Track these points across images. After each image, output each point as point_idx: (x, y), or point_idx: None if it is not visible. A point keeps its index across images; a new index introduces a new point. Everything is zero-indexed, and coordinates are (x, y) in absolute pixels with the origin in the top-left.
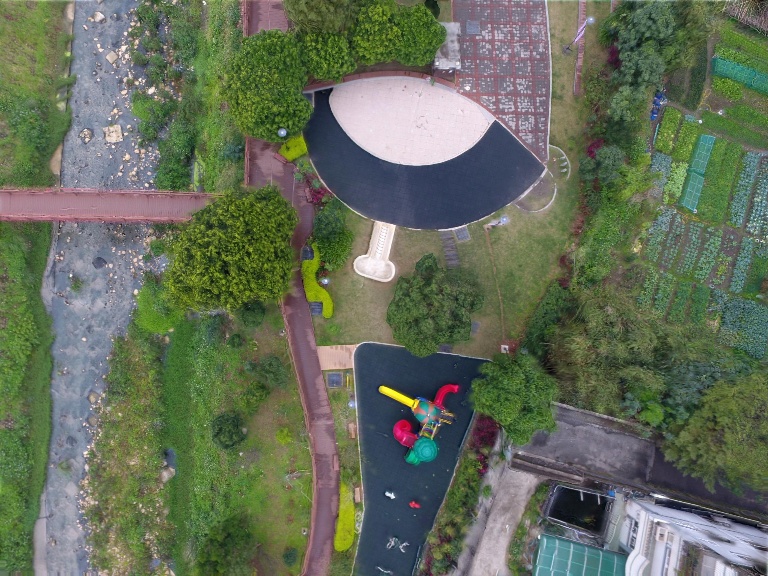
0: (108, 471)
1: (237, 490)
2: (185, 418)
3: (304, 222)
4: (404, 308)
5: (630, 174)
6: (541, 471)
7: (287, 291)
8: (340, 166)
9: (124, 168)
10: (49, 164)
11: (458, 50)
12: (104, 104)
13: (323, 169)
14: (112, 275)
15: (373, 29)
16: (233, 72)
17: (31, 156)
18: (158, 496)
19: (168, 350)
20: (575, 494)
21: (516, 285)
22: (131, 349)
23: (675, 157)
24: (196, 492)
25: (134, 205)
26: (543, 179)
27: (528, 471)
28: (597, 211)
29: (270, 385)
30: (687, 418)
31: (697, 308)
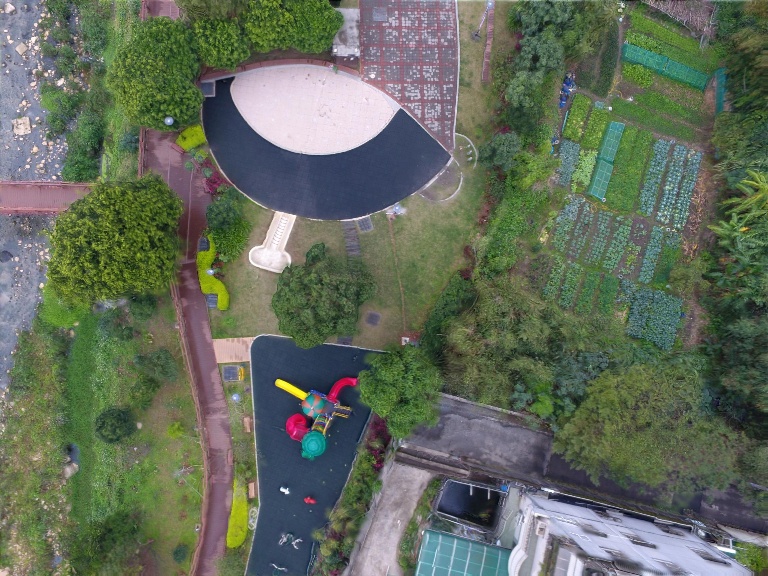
0: (11, 467)
1: (131, 486)
2: (88, 413)
3: (202, 213)
4: (284, 298)
5: (531, 162)
6: (426, 465)
7: (183, 283)
8: (240, 156)
9: (32, 160)
10: None
11: (357, 37)
12: (13, 96)
13: (223, 159)
14: (18, 269)
15: (263, 15)
16: (121, 60)
17: None
18: (60, 492)
19: (73, 344)
20: (465, 489)
21: (418, 276)
22: (35, 343)
23: (584, 145)
24: (95, 488)
25: (26, 196)
26: (449, 168)
27: (412, 465)
28: (501, 200)
29: (158, 378)
30: (574, 410)
31: (605, 299)
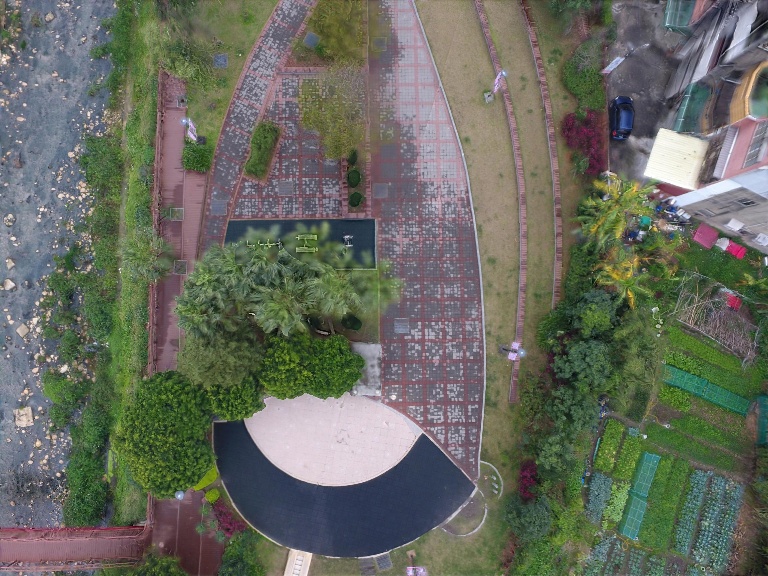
0: None
1: None
2: None
3: (213, 555)
4: None
5: (562, 518)
6: None
7: None
8: (254, 488)
9: (35, 455)
10: None
11: (378, 376)
12: (14, 382)
13: (235, 492)
14: (22, 574)
15: (279, 377)
16: (128, 424)
17: None
18: None
19: None
20: None
21: None
22: None
23: (616, 476)
24: None
25: (30, 545)
26: (473, 499)
27: None
28: (528, 544)
29: None
30: None
31: None
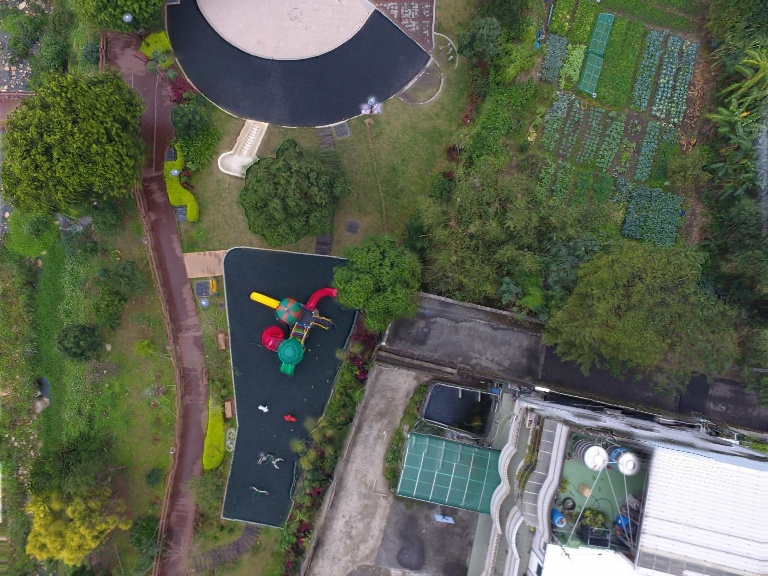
0: None
1: (102, 410)
2: None
3: (168, 123)
4: (252, 191)
5: (514, 52)
6: (409, 364)
7: (151, 196)
8: (208, 64)
9: None
10: None
11: None
12: None
13: (189, 67)
14: None
15: None
16: None
17: None
18: (31, 427)
19: (41, 274)
20: (453, 392)
21: (399, 180)
22: (1, 274)
23: (571, 39)
24: (66, 419)
25: None
26: (428, 69)
27: (395, 364)
28: (485, 98)
29: (125, 290)
30: (567, 297)
31: (599, 199)
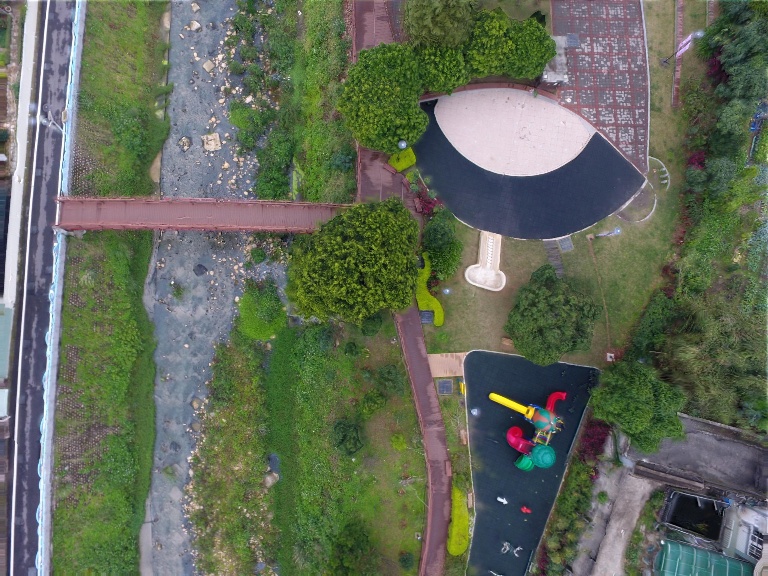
0: (213, 476)
1: (350, 495)
2: (289, 424)
3: None
4: (531, 318)
5: (735, 186)
6: (663, 478)
7: None
8: (446, 176)
9: (223, 176)
10: (149, 172)
11: (565, 63)
12: (201, 112)
13: (430, 179)
14: (213, 282)
15: (490, 43)
16: (353, 84)
17: (133, 164)
18: (263, 501)
19: (270, 357)
20: (692, 500)
21: (620, 294)
22: (234, 356)
23: None
24: (304, 497)
25: (249, 214)
26: (643, 190)
27: (650, 478)
28: (699, 222)
29: (389, 393)
30: None
31: None
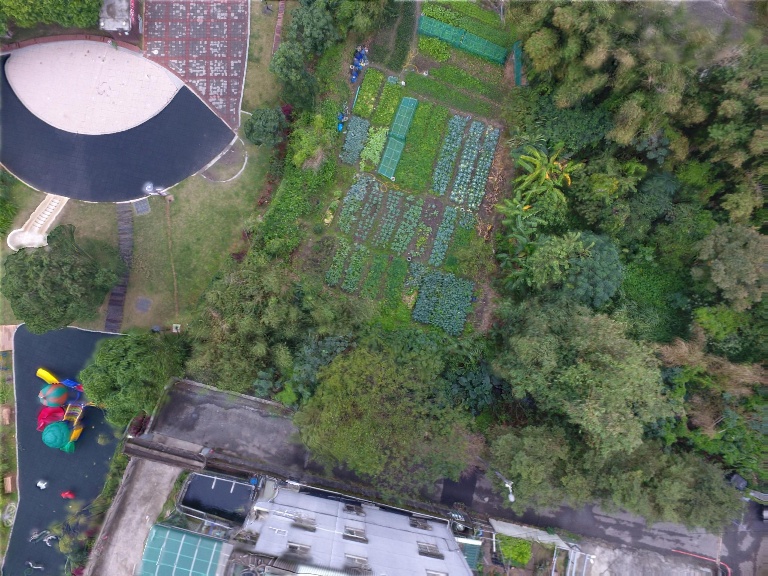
0: None
1: None
2: None
3: None
4: (7, 281)
5: (304, 138)
6: (157, 456)
7: None
8: (13, 136)
9: None
10: None
11: (126, 9)
12: None
13: None
14: None
15: None
16: None
17: None
18: None
19: None
20: (208, 482)
21: (192, 260)
22: None
23: (375, 121)
24: None
25: None
26: (233, 147)
27: (143, 457)
28: (282, 180)
29: None
30: (308, 397)
31: (391, 282)
